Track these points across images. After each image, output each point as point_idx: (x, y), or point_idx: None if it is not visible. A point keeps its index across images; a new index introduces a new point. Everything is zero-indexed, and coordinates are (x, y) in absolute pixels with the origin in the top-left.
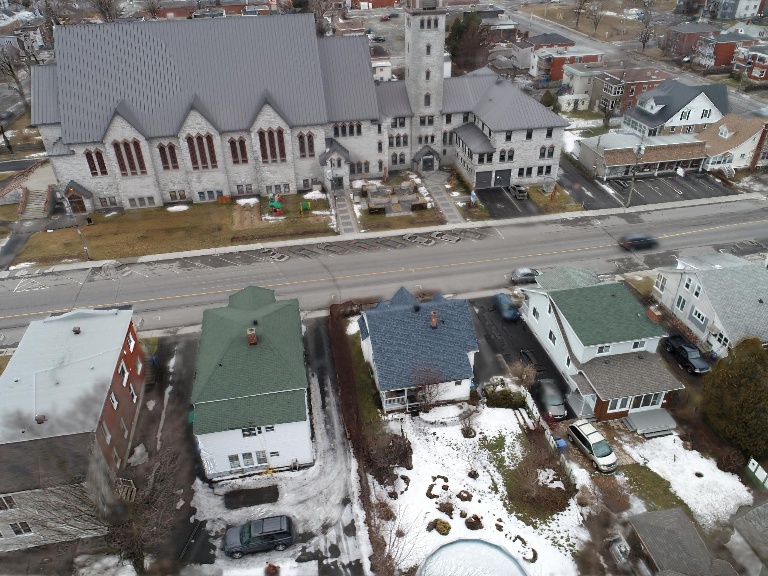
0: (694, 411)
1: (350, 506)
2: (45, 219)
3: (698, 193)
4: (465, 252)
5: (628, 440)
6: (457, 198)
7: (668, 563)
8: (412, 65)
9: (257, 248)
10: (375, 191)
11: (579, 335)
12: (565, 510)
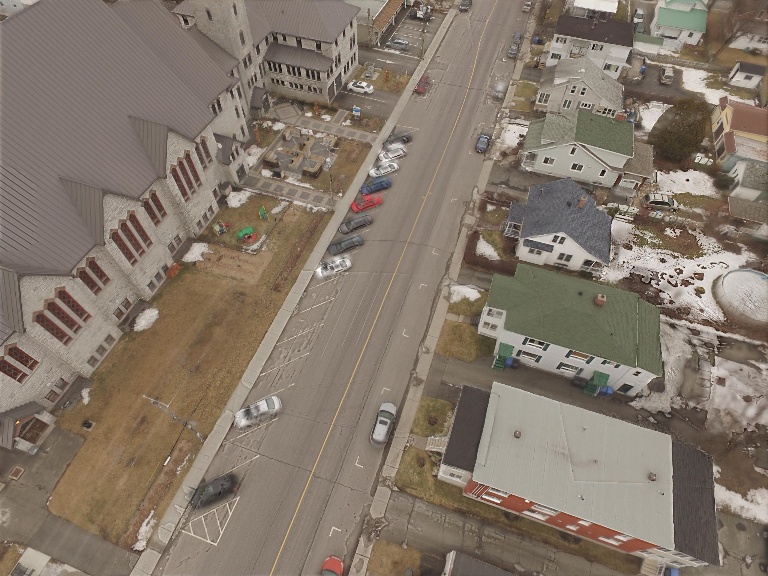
0: (656, 154)
1: (677, 325)
2: (8, 488)
3: (432, 26)
4: (425, 156)
5: (655, 189)
6: (335, 120)
7: (763, 218)
8: (222, 4)
9: (310, 276)
10: (276, 157)
11: (622, 153)
12: (696, 238)
